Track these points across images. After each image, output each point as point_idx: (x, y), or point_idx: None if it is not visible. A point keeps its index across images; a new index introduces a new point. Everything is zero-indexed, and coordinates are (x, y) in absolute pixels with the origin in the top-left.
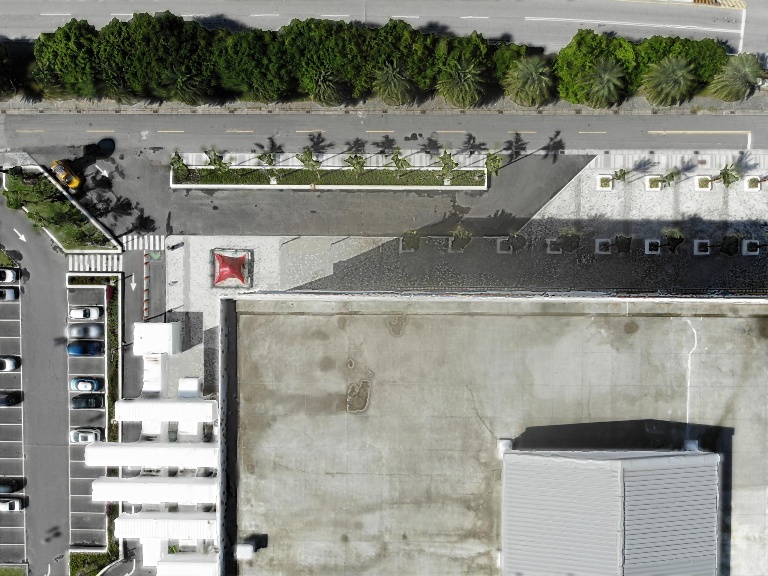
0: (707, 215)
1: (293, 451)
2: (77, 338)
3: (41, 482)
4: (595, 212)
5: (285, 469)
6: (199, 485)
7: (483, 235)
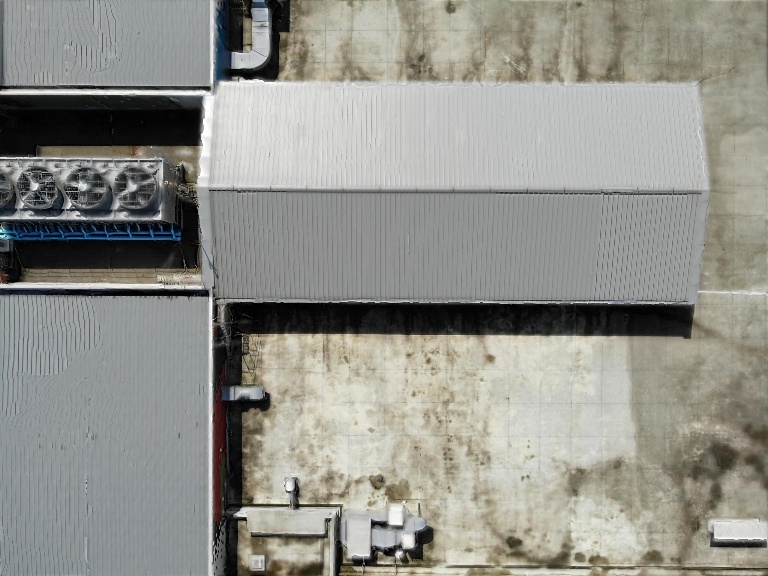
0: None
1: None
2: None
3: None
4: None
5: None
6: None
7: None
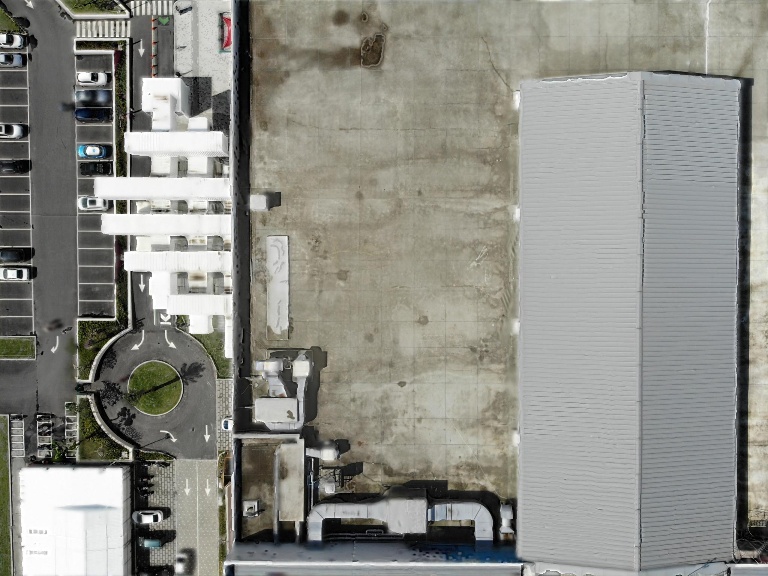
0: None
1: (306, 107)
2: (85, 105)
3: (49, 253)
4: None
5: (298, 125)
6: (209, 215)
7: None
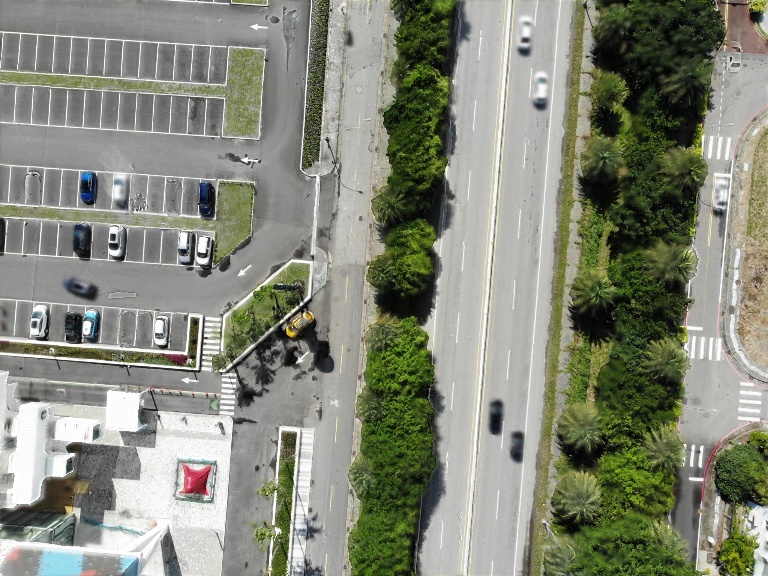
0: None
1: None
2: None
3: None
4: None
5: None
6: None
7: None
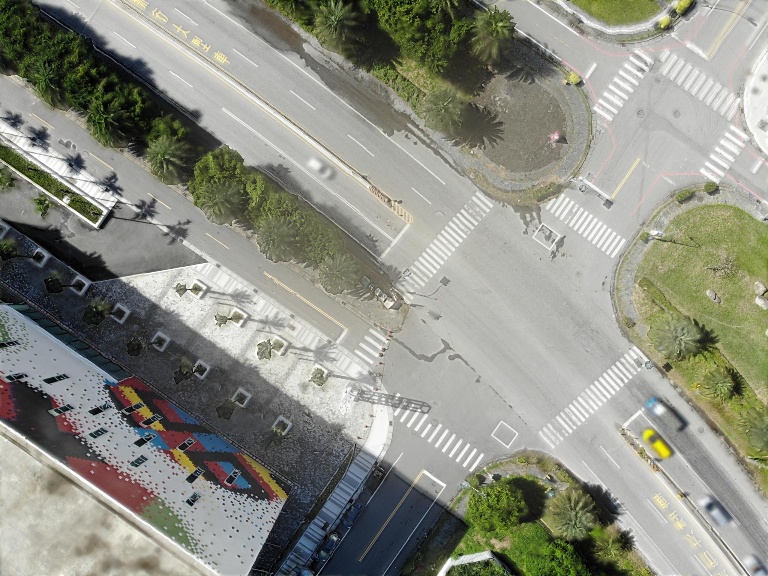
0: (265, 374)
1: None
2: None
3: None
4: (174, 308)
5: None
6: None
7: (70, 264)
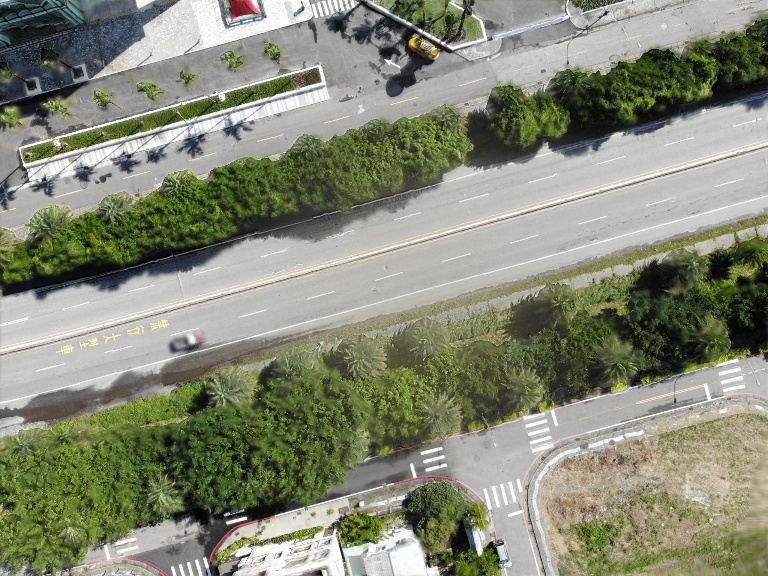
0: None
1: None
2: None
3: None
4: None
5: None
6: None
7: (12, 103)
